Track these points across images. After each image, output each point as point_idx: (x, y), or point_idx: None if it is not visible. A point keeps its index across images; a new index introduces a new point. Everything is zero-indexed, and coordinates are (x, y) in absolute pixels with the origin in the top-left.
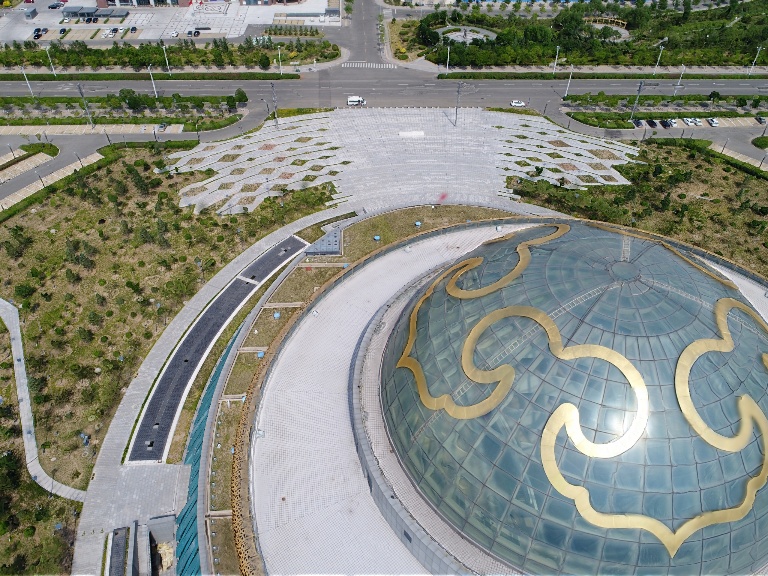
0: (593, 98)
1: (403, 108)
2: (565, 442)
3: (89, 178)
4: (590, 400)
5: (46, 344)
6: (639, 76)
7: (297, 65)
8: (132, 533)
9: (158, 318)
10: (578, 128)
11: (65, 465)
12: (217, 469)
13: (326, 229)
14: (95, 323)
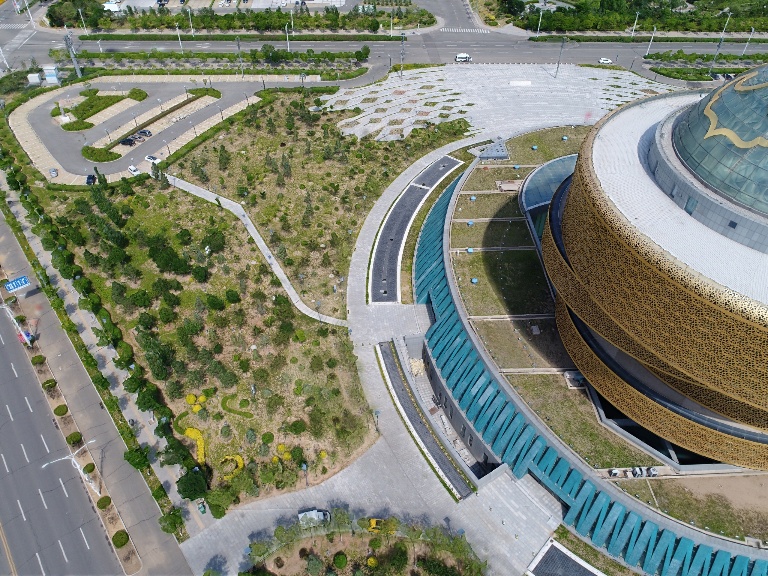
0: (674, 55)
1: (505, 64)
2: None
3: None
4: None
5: (274, 228)
6: (708, 40)
7: (401, 29)
8: (396, 343)
9: (357, 212)
10: (663, 80)
11: (324, 304)
12: (464, 292)
13: (472, 151)
14: (310, 213)
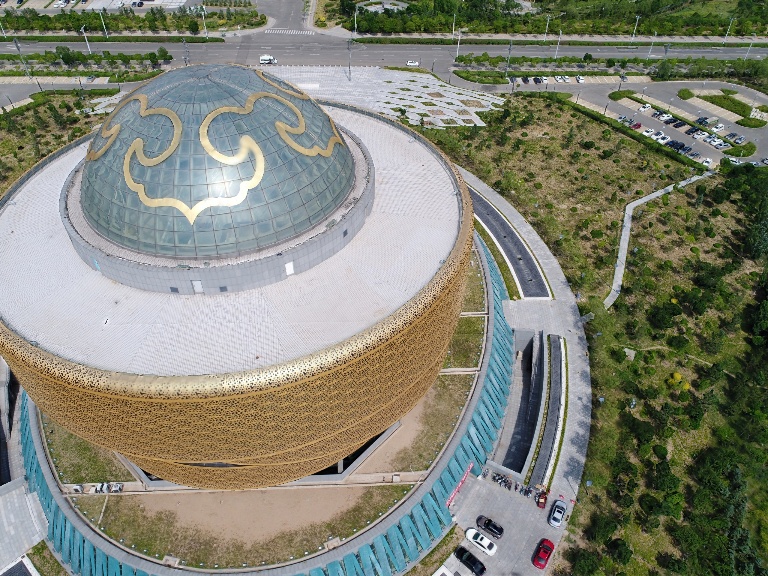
0: None
1: (309, 66)
2: (135, 160)
3: (18, 117)
4: (151, 136)
5: None
6: (530, 42)
7: (224, 31)
8: None
9: None
10: (459, 83)
11: None
12: None
13: None
14: None
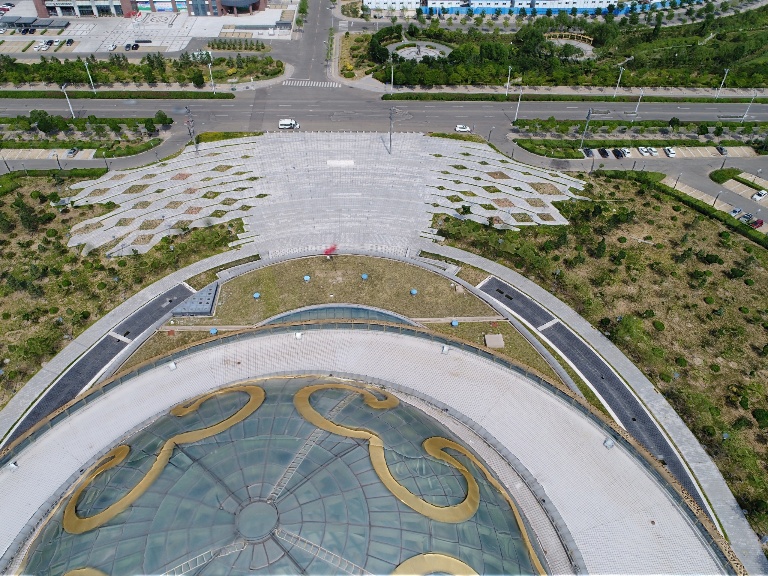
0: (542, 124)
1: (338, 132)
2: None
3: None
4: None
5: None
6: (598, 98)
7: (234, 83)
8: None
9: (8, 383)
10: (523, 157)
11: None
12: None
13: (221, 275)
14: None
